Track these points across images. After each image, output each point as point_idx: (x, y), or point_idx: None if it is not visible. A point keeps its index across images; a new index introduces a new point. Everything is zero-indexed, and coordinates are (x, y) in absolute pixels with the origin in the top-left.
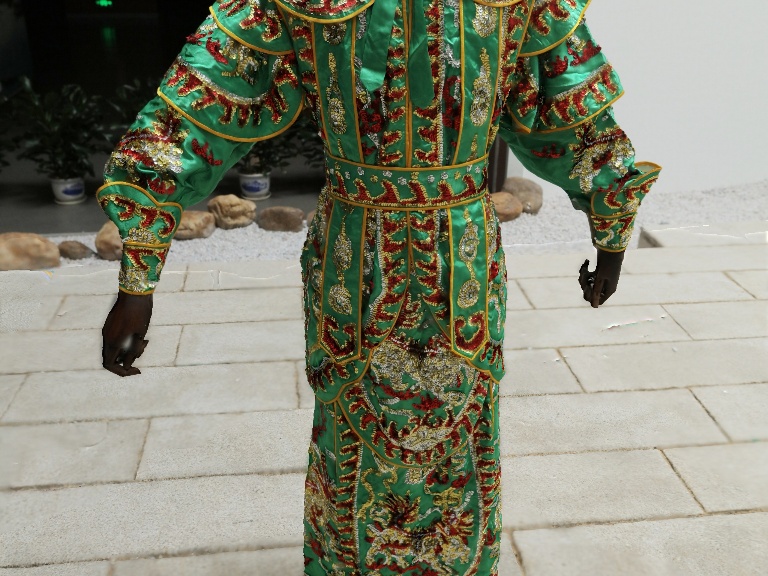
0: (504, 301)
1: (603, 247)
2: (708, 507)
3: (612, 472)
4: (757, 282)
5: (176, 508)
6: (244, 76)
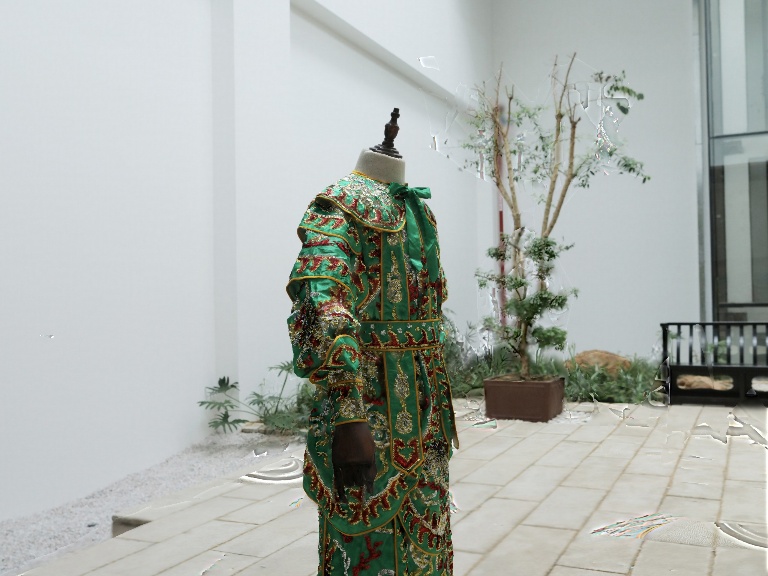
0: None
1: None
2: None
3: None
4: (245, 517)
5: None
6: None
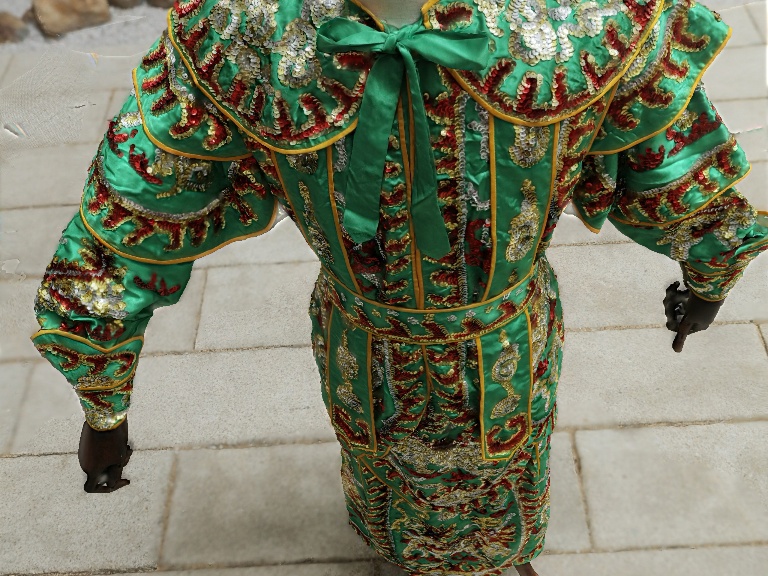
0: (557, 372)
1: (697, 293)
2: None
3: (695, 356)
4: None
5: (234, 389)
6: (190, 187)
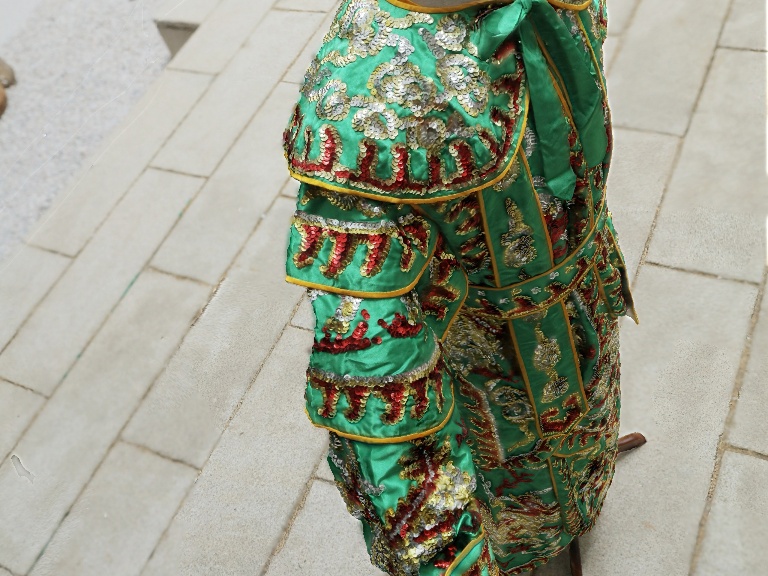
0: None
1: None
2: None
3: None
4: None
5: None
6: None
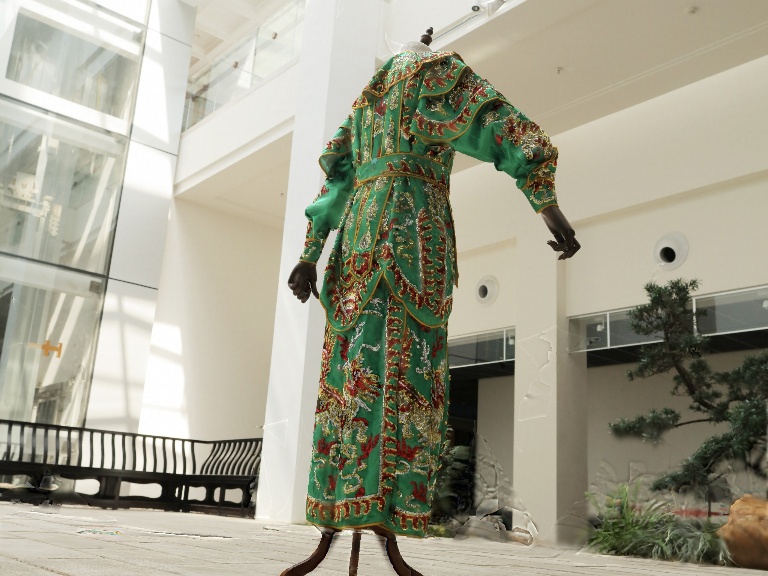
0: None
1: None
2: (103, 558)
3: None
4: None
5: None
6: None
